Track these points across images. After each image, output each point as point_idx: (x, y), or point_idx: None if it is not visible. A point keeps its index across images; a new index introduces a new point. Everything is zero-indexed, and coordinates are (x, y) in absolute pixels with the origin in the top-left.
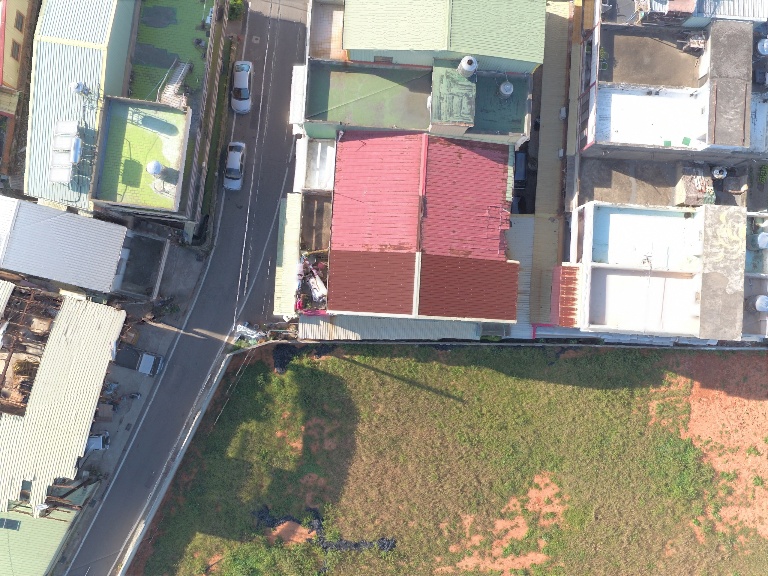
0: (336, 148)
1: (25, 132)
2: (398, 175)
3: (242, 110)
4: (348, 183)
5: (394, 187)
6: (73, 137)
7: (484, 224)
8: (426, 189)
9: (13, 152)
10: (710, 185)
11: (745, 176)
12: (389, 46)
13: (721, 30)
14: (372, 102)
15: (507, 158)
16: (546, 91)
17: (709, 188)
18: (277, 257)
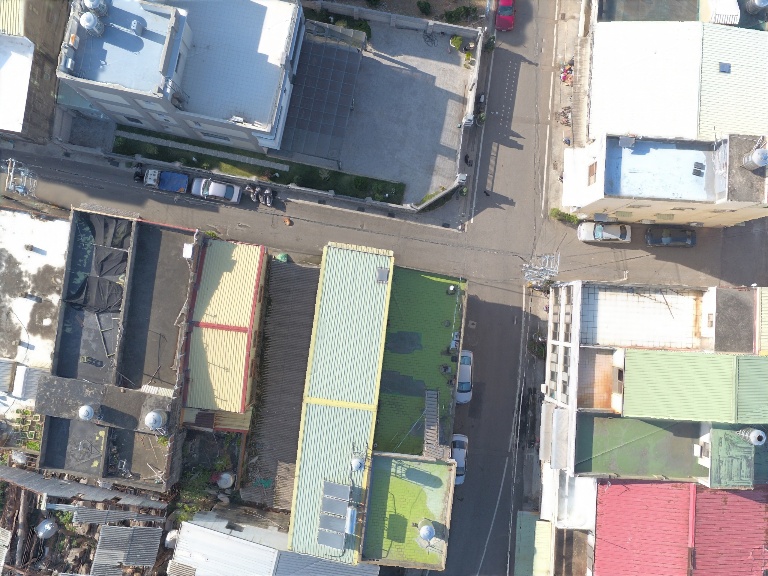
0: (597, 491)
1: (255, 442)
2: (665, 525)
3: (462, 401)
4: (611, 529)
5: (661, 537)
6: (345, 503)
7: (748, 567)
8: (695, 540)
9: (245, 465)
10: None
11: None
12: (670, 413)
13: None
14: (636, 448)
15: None
16: None
17: None
18: (515, 571)
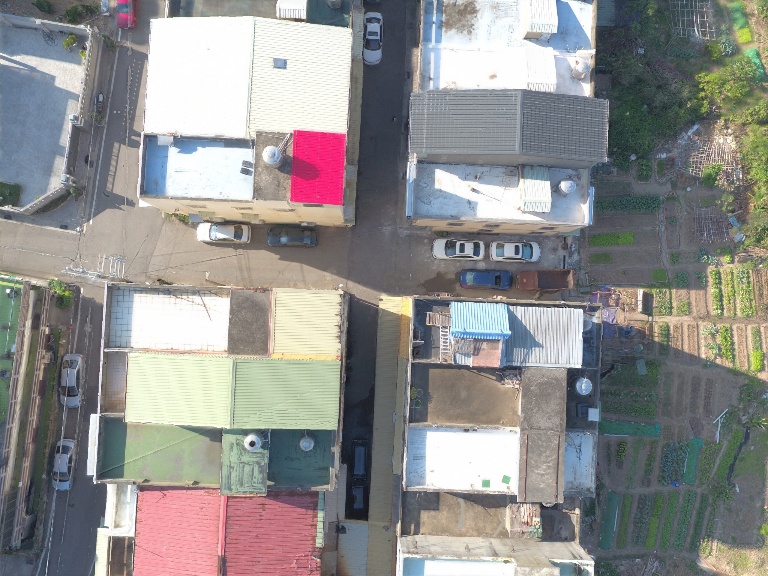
0: (137, 497)
1: None
2: (197, 532)
3: (72, 405)
4: (148, 536)
5: (193, 544)
6: None
7: (291, 575)
8: (226, 548)
9: None
10: (537, 516)
11: (578, 499)
12: (174, 418)
13: (532, 378)
14: (171, 453)
15: (317, 502)
16: (380, 391)
17: (535, 520)
18: None
